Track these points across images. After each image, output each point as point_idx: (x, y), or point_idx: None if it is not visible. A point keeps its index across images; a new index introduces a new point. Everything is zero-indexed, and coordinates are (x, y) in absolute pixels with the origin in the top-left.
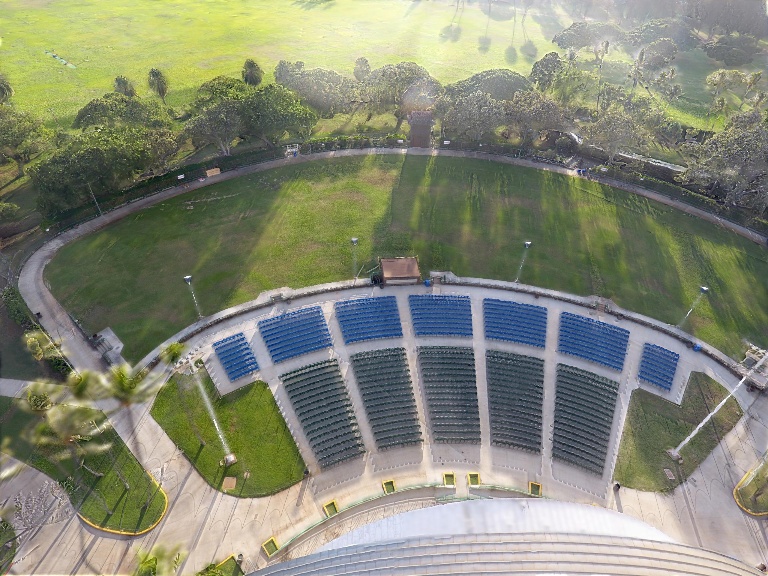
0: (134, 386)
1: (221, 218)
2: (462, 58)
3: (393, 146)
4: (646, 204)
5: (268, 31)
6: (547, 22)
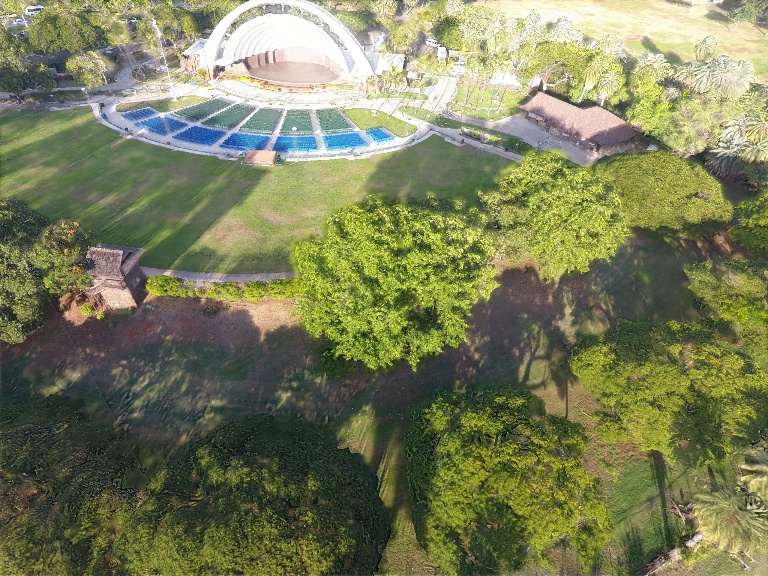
0: None
1: None
2: None
3: None
4: None
5: None
6: None
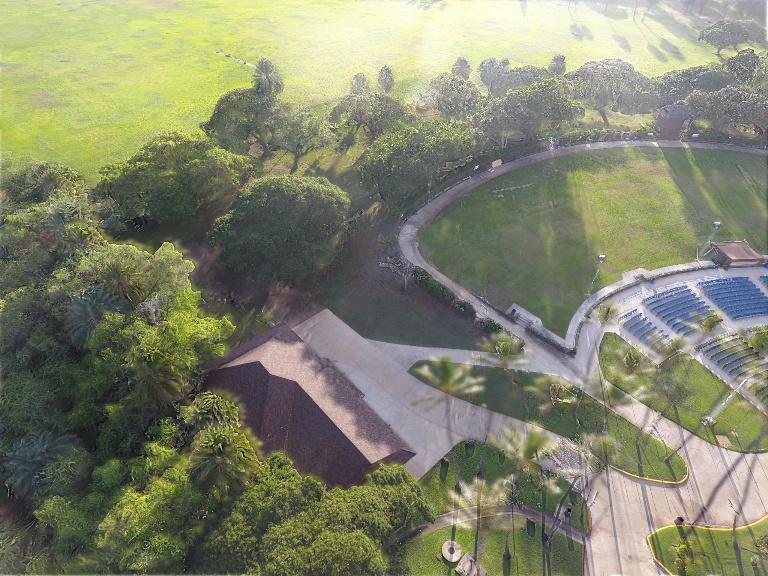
0: (574, 356)
1: (535, 205)
2: (612, 56)
3: (642, 139)
4: None
5: (407, 31)
6: (665, 20)
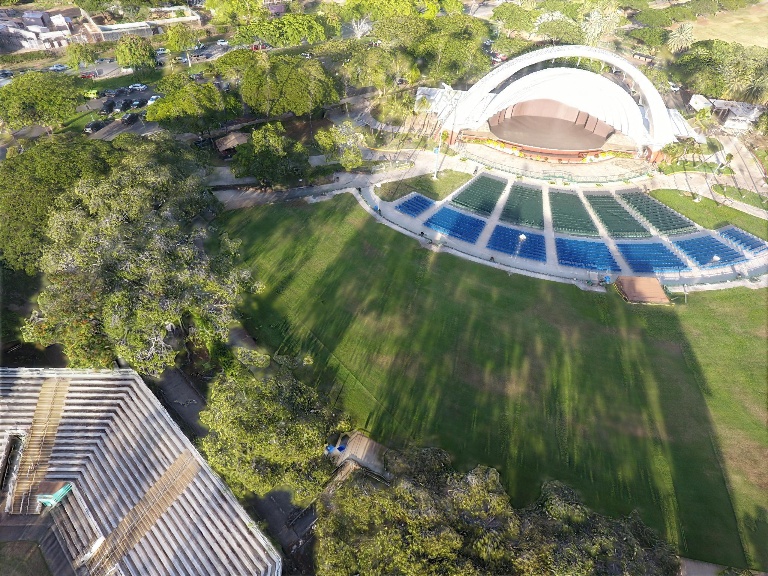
0: None
1: None
2: None
3: None
4: (287, 343)
5: None
6: None
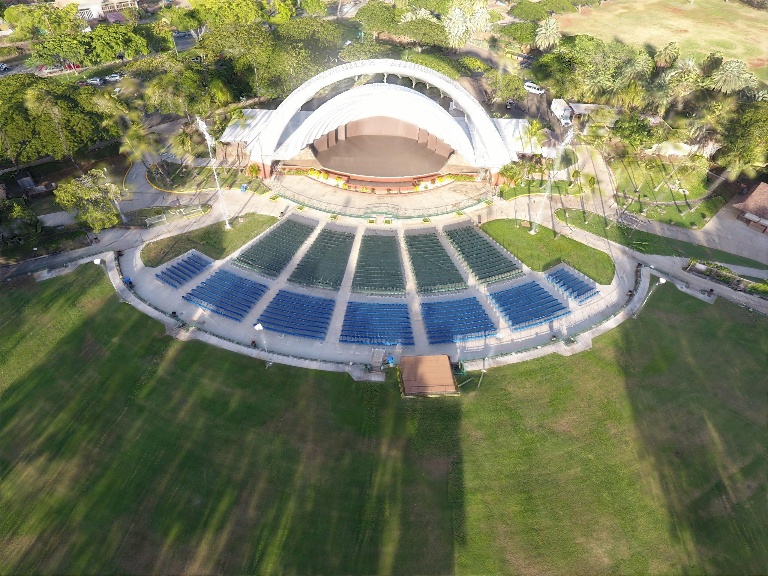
0: None
1: (762, 486)
2: None
3: None
4: None
5: None
6: None
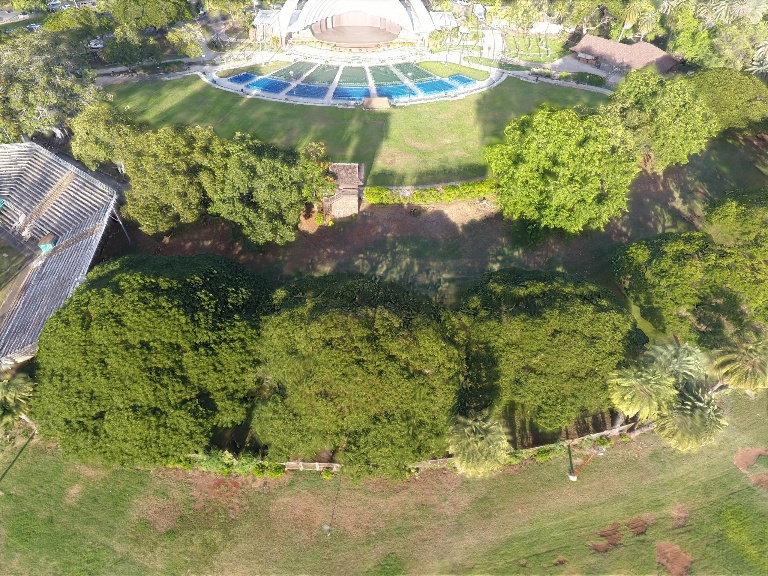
0: None
1: None
2: None
3: None
4: None
5: None
6: None
